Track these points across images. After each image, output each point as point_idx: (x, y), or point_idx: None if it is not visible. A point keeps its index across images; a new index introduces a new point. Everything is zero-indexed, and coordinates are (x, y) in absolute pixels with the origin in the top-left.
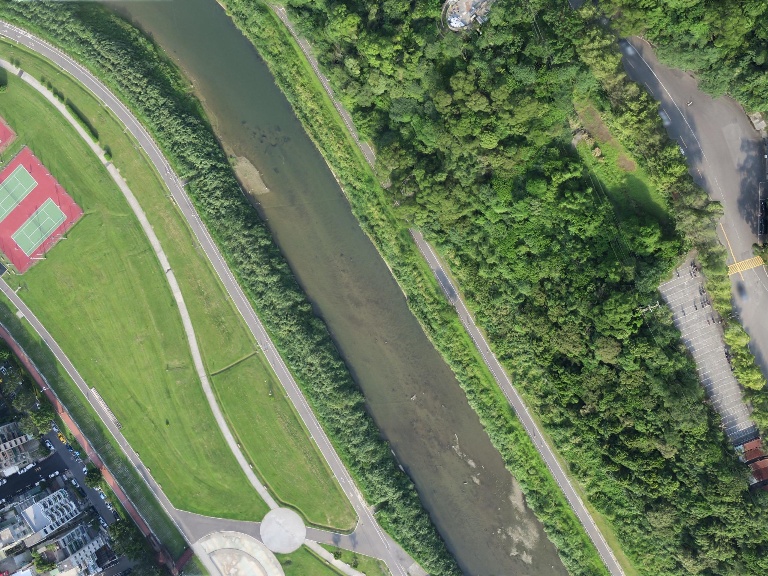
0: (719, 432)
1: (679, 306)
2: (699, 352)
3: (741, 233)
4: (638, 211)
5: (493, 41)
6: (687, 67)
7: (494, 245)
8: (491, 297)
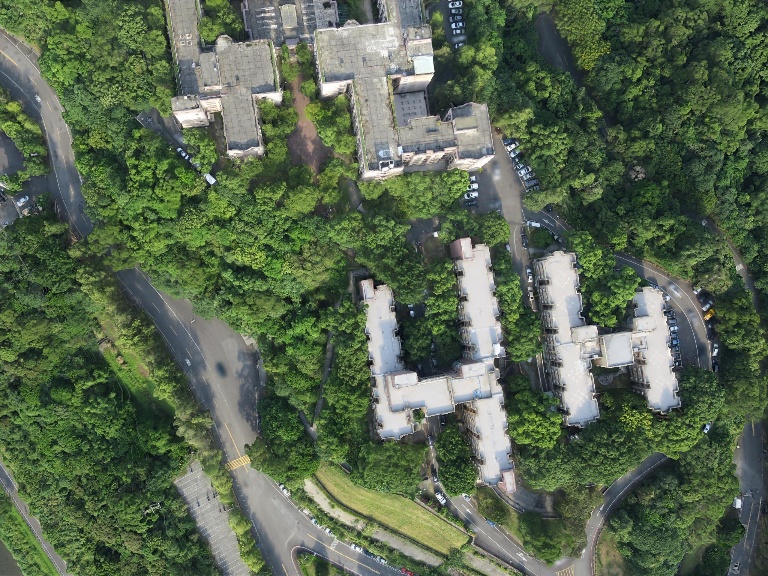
0: None
1: (194, 498)
2: (214, 538)
3: (242, 431)
4: (158, 412)
5: (0, 268)
6: (176, 297)
7: (35, 443)
8: (41, 489)
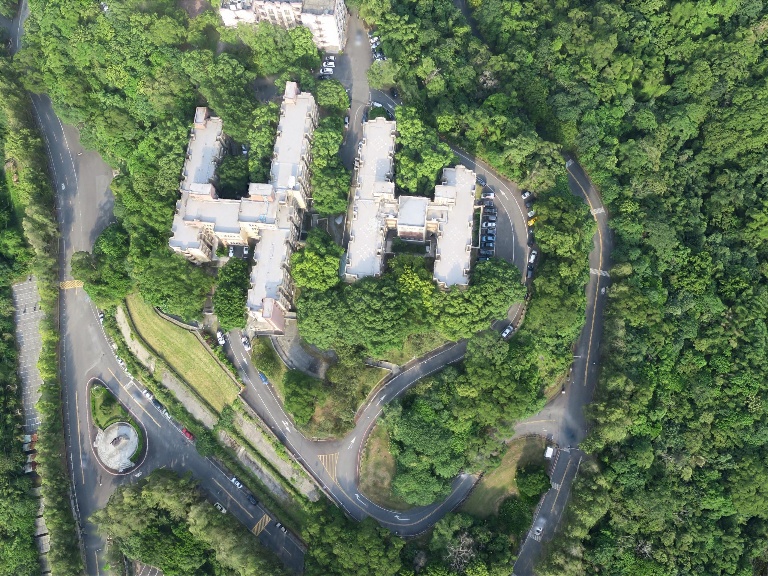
0: (8, 414)
1: (24, 305)
2: (26, 347)
3: None
4: None
5: None
6: None
7: None
8: None
